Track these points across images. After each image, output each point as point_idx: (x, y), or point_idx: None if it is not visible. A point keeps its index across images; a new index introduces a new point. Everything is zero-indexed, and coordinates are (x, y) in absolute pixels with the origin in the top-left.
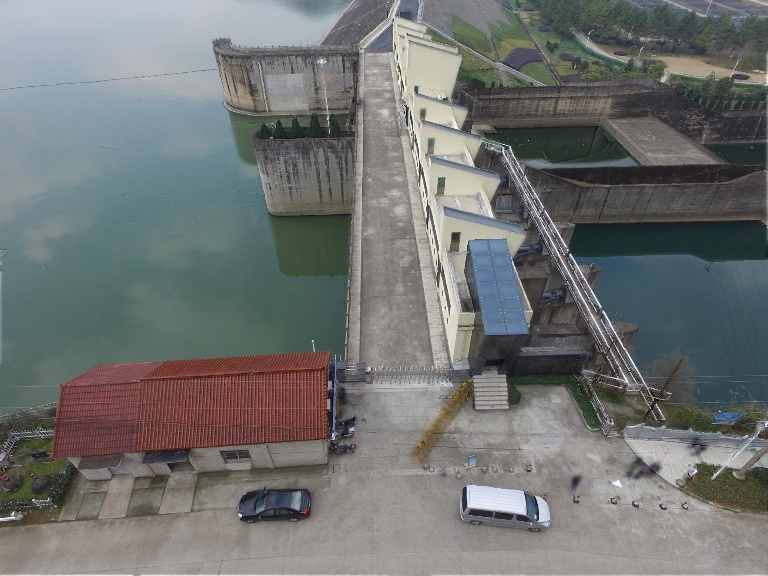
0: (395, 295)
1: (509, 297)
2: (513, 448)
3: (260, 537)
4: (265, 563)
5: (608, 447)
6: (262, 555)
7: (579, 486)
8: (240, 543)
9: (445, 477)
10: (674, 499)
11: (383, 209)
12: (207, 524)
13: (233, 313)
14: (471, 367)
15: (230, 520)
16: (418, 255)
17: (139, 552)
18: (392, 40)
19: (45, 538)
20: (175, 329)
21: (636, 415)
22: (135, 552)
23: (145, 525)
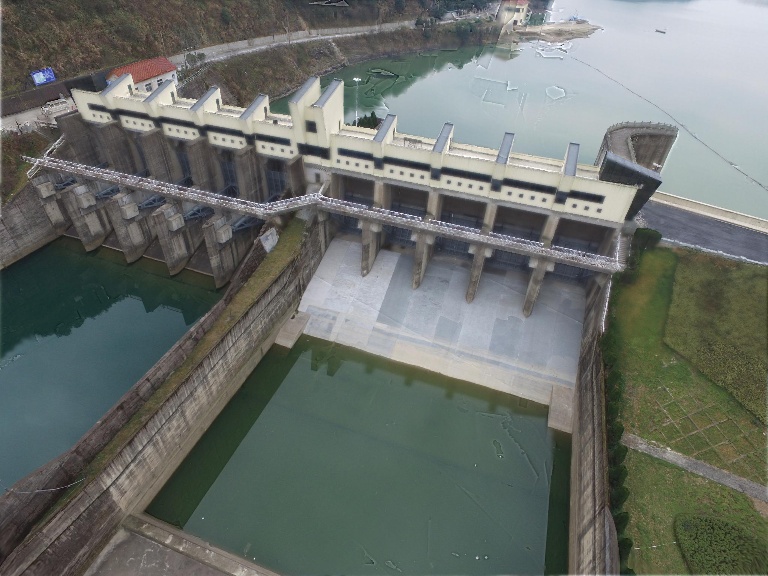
0: None
1: None
2: None
3: None
4: None
5: None
6: None
7: None
8: None
9: None
10: (8, 129)
11: None
12: None
13: None
14: None
15: None
16: None
17: None
18: (710, 231)
19: None
20: None
21: None
22: None
23: None
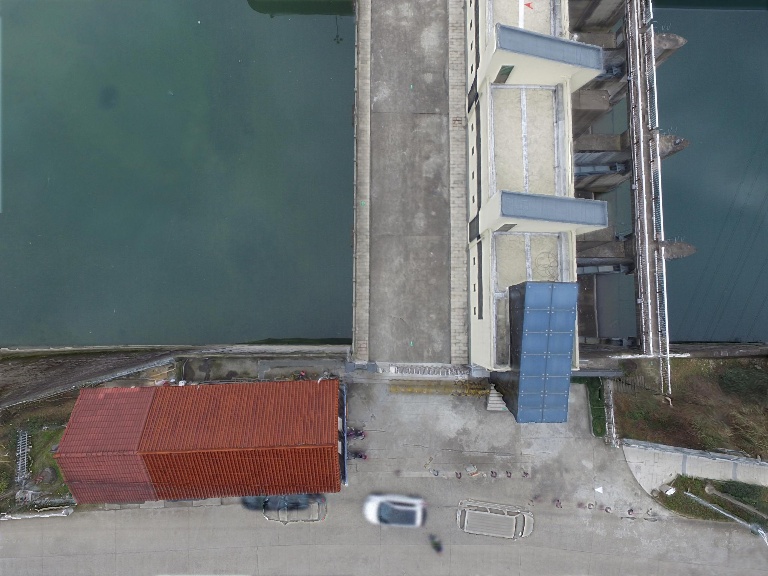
0: (413, 234)
1: (557, 376)
2: (515, 453)
3: (286, 529)
4: (293, 550)
5: (604, 454)
6: (290, 543)
7: (565, 492)
8: (270, 533)
9: (447, 480)
10: (643, 506)
11: (404, 35)
12: (238, 516)
13: (201, 138)
14: (491, 375)
15: (257, 514)
16: (449, 155)
17: (186, 538)
18: None
19: (101, 524)
20: (134, 162)
21: (645, 384)
22: (183, 538)
23: (184, 516)
